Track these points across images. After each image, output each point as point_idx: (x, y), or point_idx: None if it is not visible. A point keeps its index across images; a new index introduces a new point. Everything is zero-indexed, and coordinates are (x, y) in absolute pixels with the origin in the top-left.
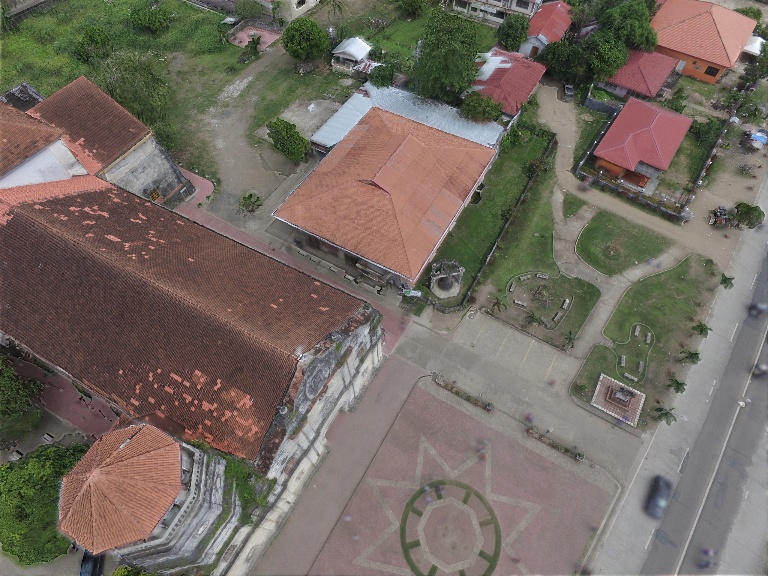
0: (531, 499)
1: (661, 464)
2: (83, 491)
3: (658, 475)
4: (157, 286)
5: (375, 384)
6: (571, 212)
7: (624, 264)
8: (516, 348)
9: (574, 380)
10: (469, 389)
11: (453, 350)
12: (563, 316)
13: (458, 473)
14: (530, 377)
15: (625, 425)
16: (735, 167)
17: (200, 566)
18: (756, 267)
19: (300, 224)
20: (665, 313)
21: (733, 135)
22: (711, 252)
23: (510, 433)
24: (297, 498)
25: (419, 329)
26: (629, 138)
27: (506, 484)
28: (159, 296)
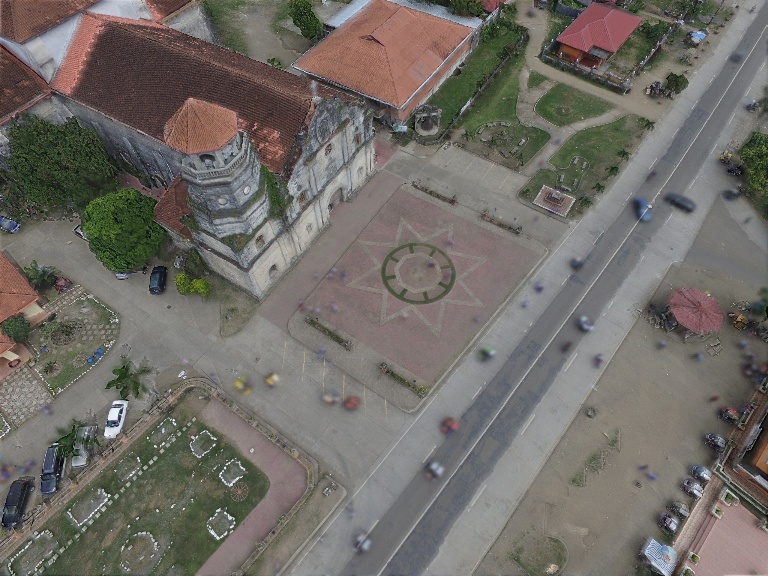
0: (480, 255)
1: (581, 239)
2: (183, 111)
3: (578, 245)
4: (212, 64)
5: (368, 187)
6: (534, 84)
7: (572, 119)
8: (479, 168)
9: (522, 189)
10: (440, 192)
11: (430, 168)
12: (519, 150)
13: (427, 239)
14: (488, 186)
15: (557, 216)
16: (676, 57)
17: (242, 235)
18: (679, 124)
19: (313, 71)
20: (600, 150)
21: (679, 35)
22: (644, 113)
23: (469, 218)
24: (306, 249)
25: (404, 155)
26: (586, 27)
27: (462, 246)
28: (214, 71)
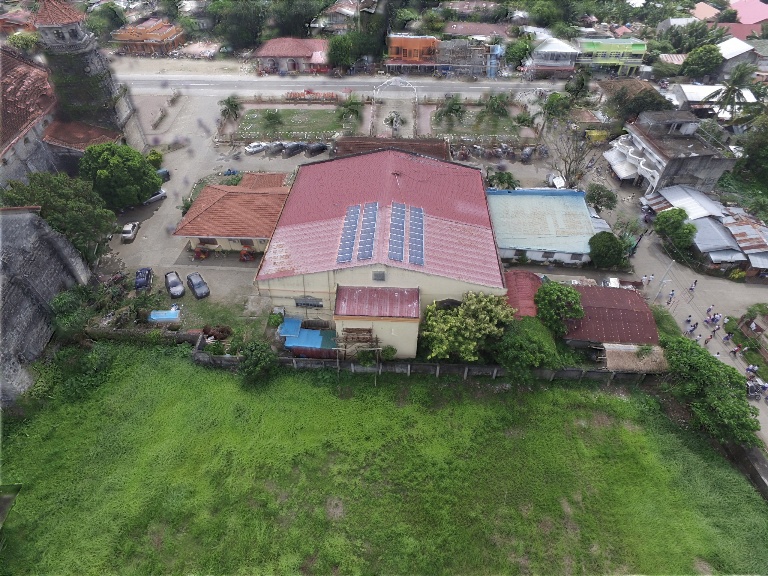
0: None
1: None
2: None
3: None
4: None
5: None
6: None
7: None
8: None
9: None
10: None
11: None
12: None
13: None
14: None
15: None
16: None
17: None
18: None
19: None
20: None
21: None
22: None
23: None
24: None
25: None
26: None
27: None
28: None
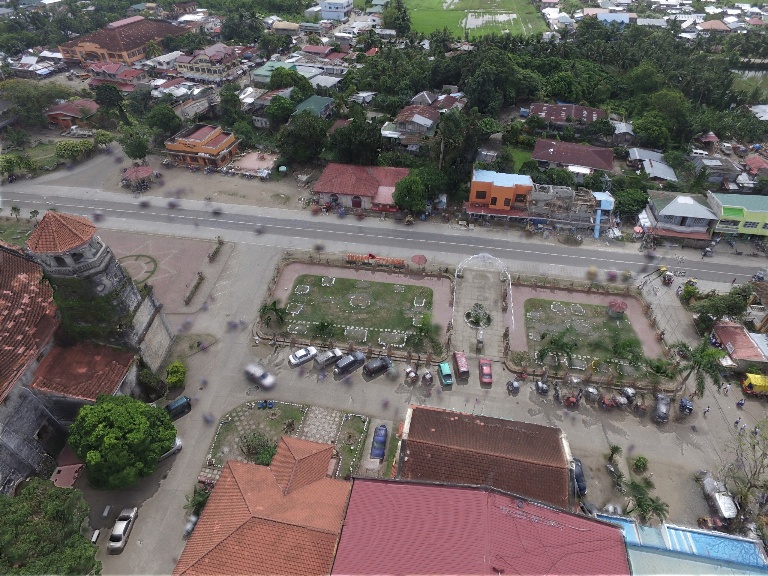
0: None
1: None
2: (60, 218)
3: None
4: None
5: None
6: None
7: None
8: None
9: None
10: None
11: None
12: None
13: None
14: None
15: None
16: None
17: None
18: None
19: None
20: None
21: None
22: None
23: None
24: None
25: None
26: None
27: None
28: None
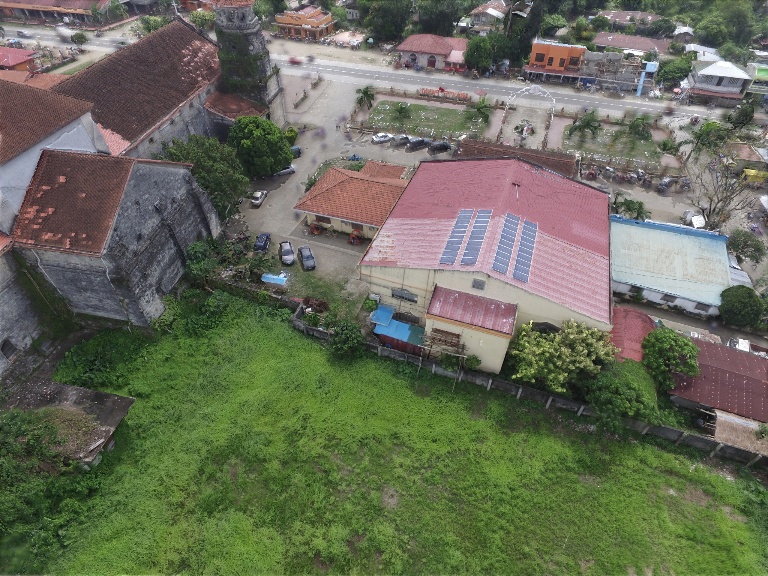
0: None
1: None
2: None
3: None
4: None
5: None
6: None
7: None
8: None
9: None
10: None
11: None
12: None
13: None
14: None
15: None
16: None
17: None
18: None
19: None
20: None
21: None
22: (99, 55)
23: None
24: None
25: None
26: None
27: None
28: (138, 47)
